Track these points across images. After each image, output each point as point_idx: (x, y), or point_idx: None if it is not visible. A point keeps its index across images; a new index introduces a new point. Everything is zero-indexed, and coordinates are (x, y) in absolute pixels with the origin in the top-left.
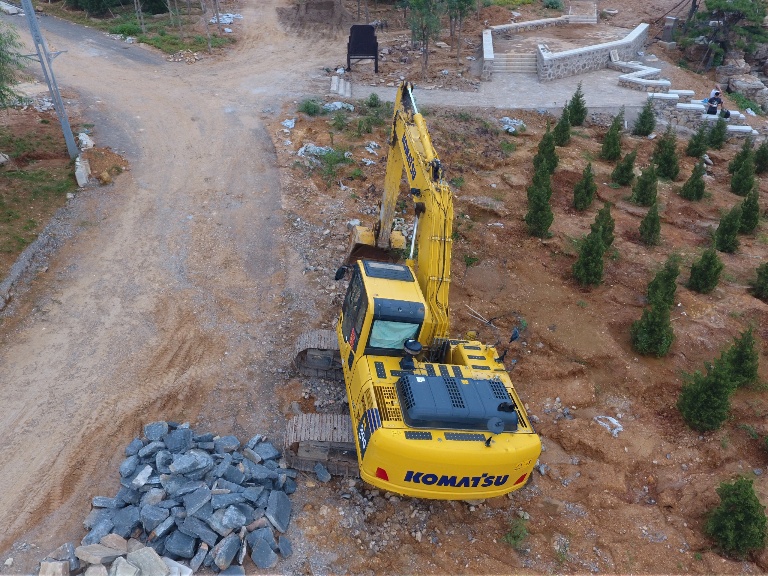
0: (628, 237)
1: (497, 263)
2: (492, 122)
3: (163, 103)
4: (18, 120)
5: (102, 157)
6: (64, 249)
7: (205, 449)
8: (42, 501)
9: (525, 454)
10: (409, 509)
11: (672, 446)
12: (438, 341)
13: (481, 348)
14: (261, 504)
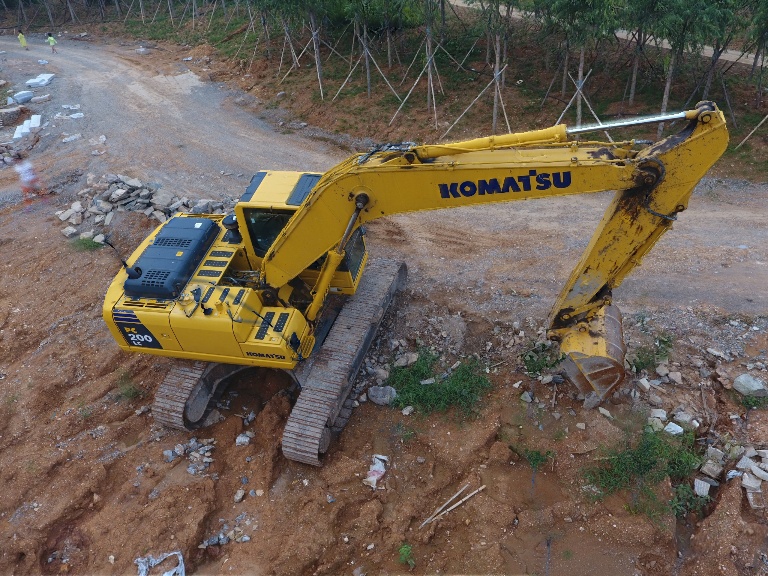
0: None
1: None
2: None
3: None
4: None
5: None
6: None
7: None
8: None
9: None
10: None
11: None
12: None
13: (236, 305)
14: None
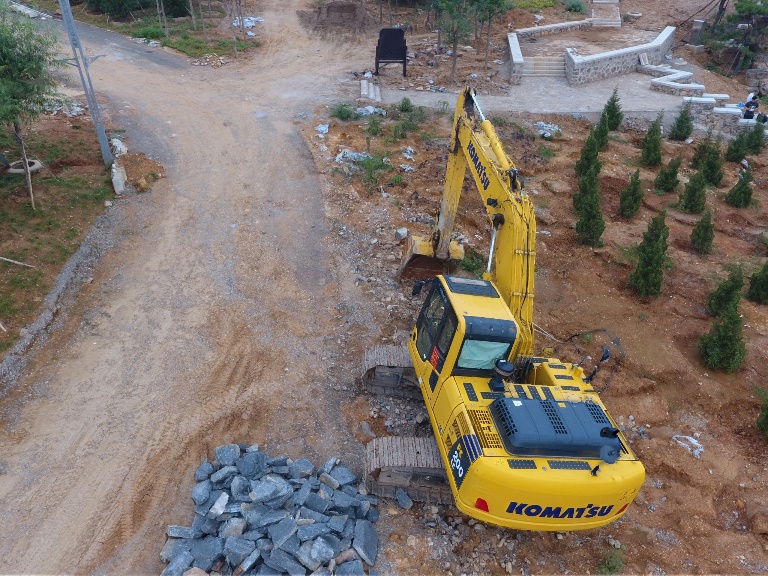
0: (678, 245)
1: (551, 273)
2: (527, 127)
3: (193, 108)
4: (49, 125)
5: (138, 163)
6: (107, 259)
7: (280, 474)
8: (113, 530)
9: (631, 483)
10: (496, 538)
11: (757, 468)
12: (521, 360)
13: (566, 367)
14: (348, 535)
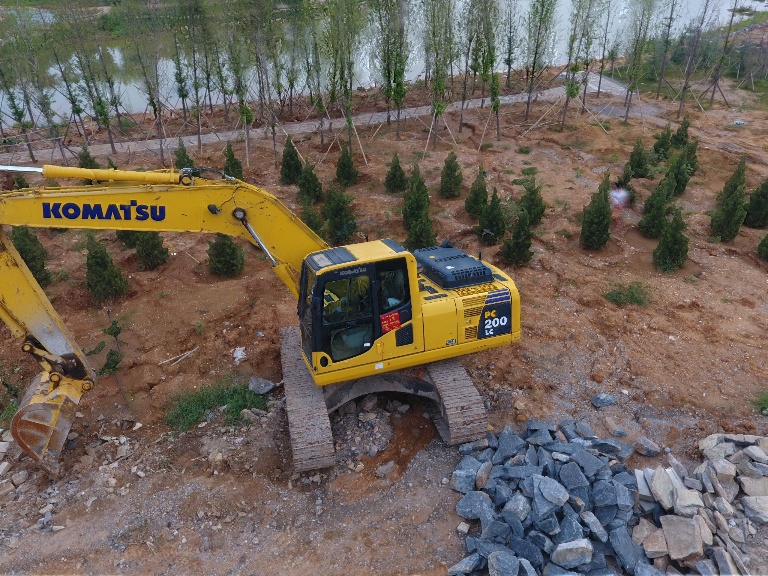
0: None
1: None
2: None
3: None
4: None
5: None
6: None
7: None
8: None
9: None
10: None
11: None
12: None
13: None
14: None
